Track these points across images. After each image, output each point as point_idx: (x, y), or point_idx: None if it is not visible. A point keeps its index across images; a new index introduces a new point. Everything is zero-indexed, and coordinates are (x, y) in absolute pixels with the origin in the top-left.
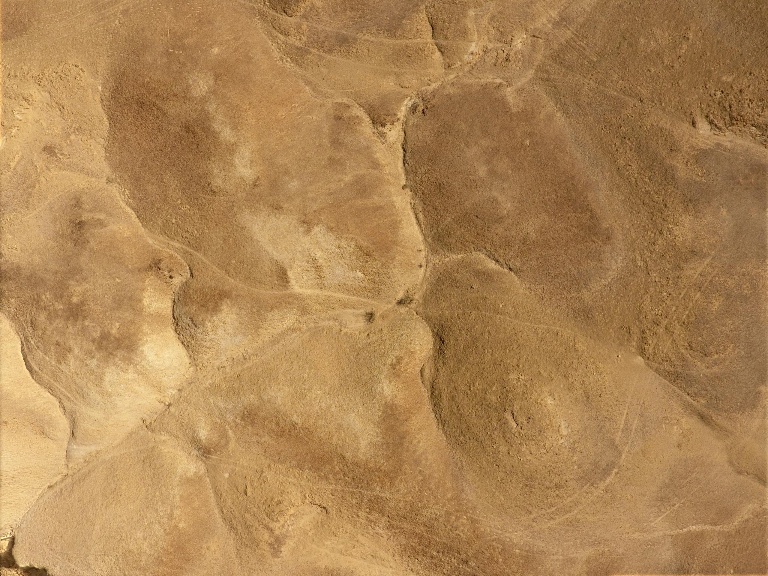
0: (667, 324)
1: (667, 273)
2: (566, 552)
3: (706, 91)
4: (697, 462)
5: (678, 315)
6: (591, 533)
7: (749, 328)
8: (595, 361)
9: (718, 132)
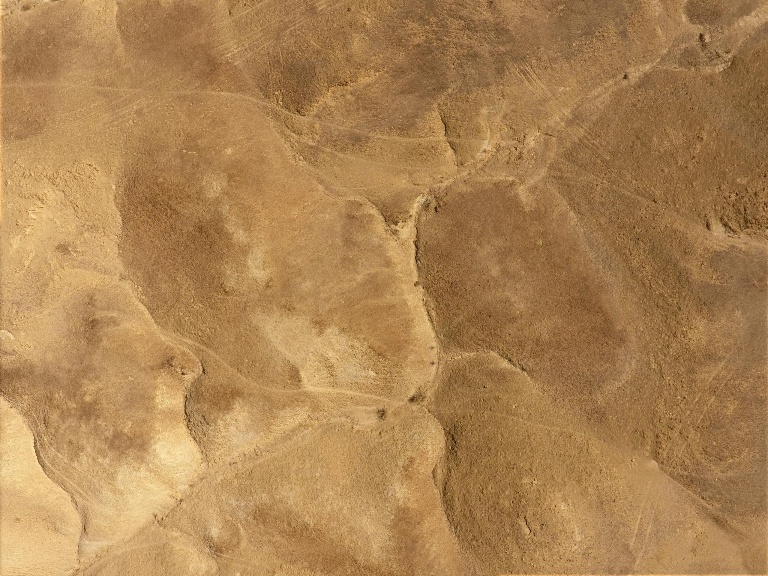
0: (681, 428)
1: (681, 376)
2: None
3: (720, 193)
4: (712, 566)
5: (692, 419)
6: None
7: (764, 431)
8: (609, 466)
9: (733, 234)
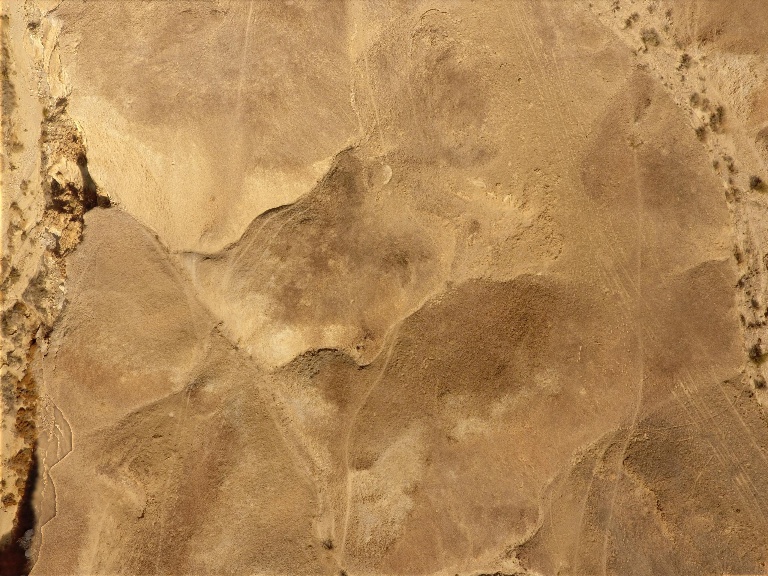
0: None
1: None
2: None
3: None
4: None
5: None
6: None
7: None
8: None
9: None
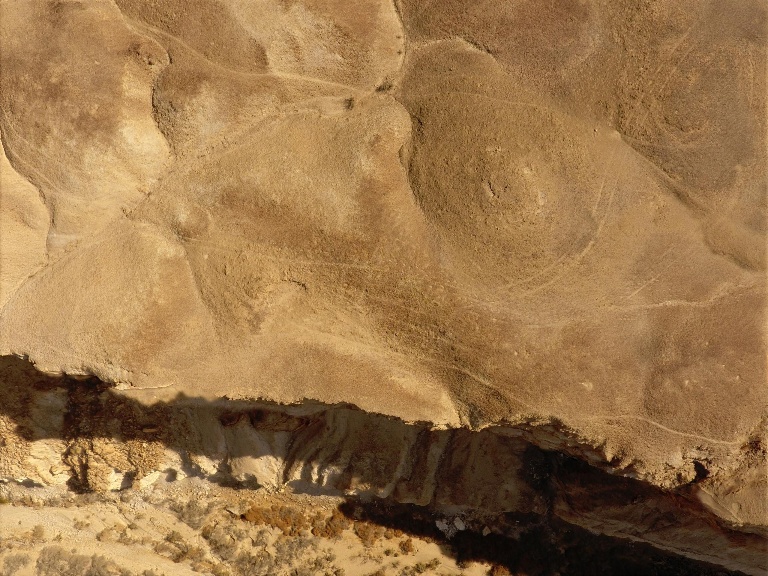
0: (644, 98)
1: (644, 48)
2: (543, 321)
3: None
4: (673, 238)
5: (654, 89)
6: (567, 304)
7: (725, 105)
8: (572, 134)
9: None
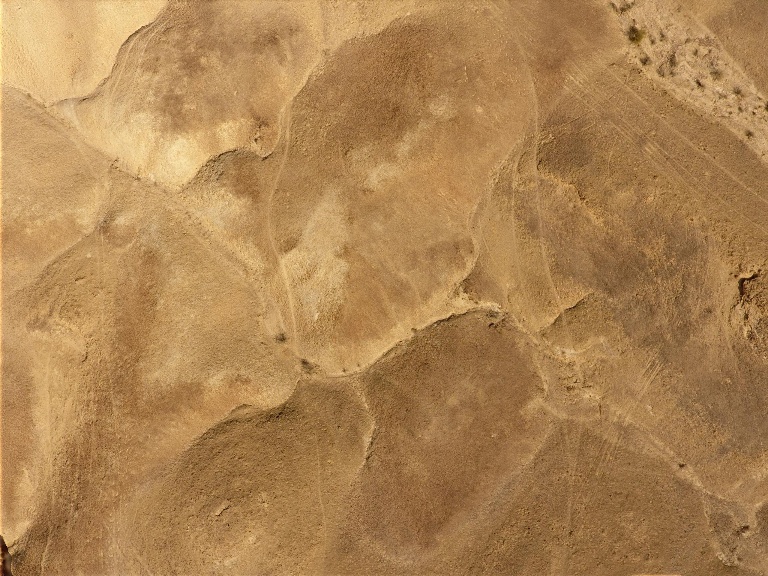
0: None
1: None
2: None
3: None
4: None
5: None
6: None
7: None
8: (304, 570)
9: None
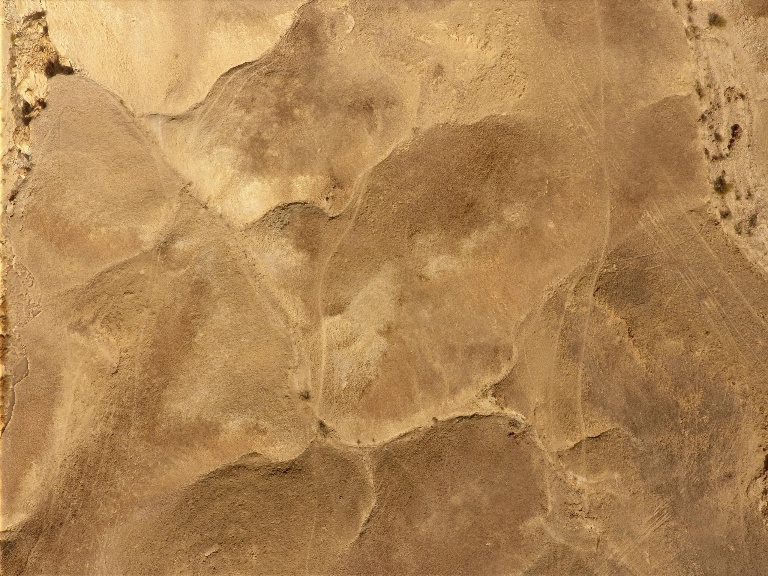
0: None
1: None
2: None
3: None
4: None
5: None
6: None
7: None
8: None
9: None
